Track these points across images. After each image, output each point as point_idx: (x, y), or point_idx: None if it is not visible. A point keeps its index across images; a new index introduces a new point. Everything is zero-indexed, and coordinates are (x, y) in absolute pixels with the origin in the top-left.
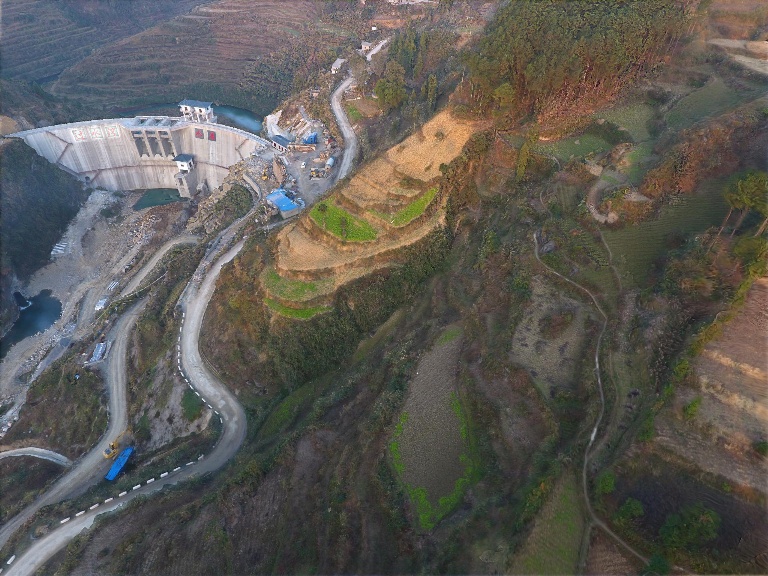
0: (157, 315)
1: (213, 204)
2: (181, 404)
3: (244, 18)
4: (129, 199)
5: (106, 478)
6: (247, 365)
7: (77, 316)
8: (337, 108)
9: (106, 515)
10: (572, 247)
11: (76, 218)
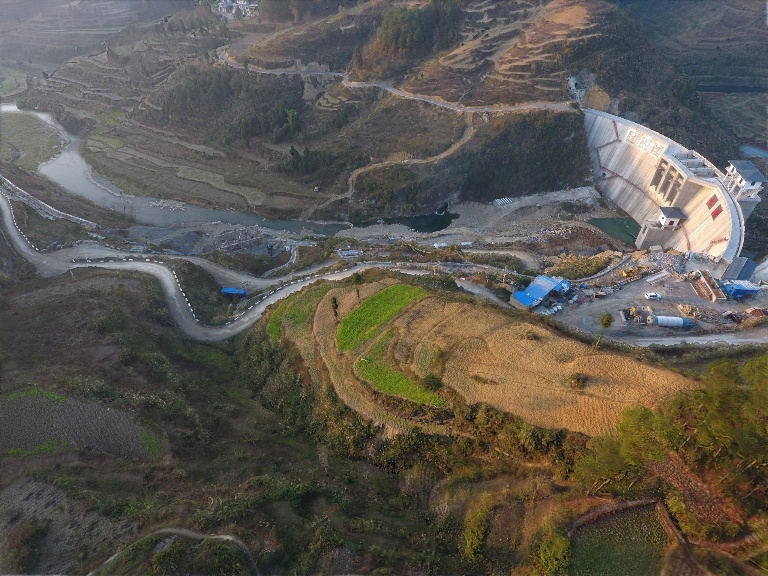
0: None
1: None
2: None
3: None
4: (604, 212)
5: (223, 288)
6: None
7: None
8: None
9: (148, 280)
10: None
11: (548, 193)
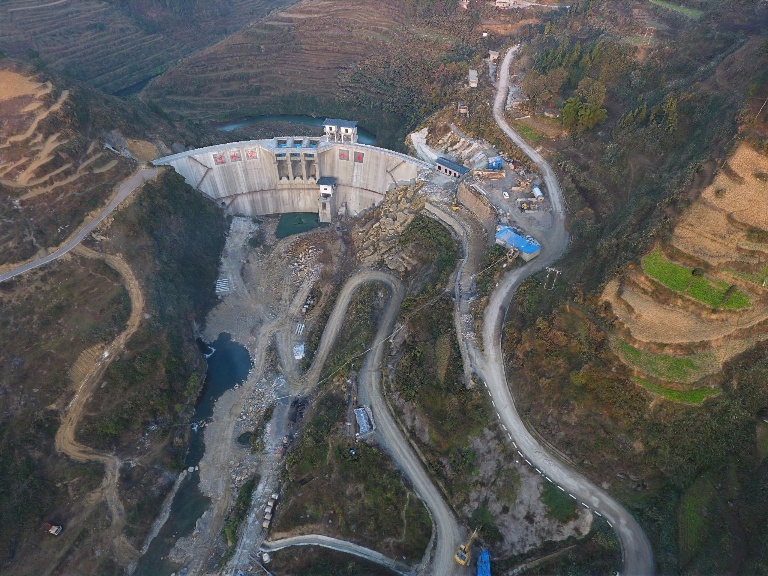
0: (435, 380)
1: (389, 235)
2: (542, 500)
3: (326, 23)
4: (267, 225)
5: None
6: (620, 455)
7: (277, 366)
8: (505, 127)
9: None
10: None
11: (226, 249)
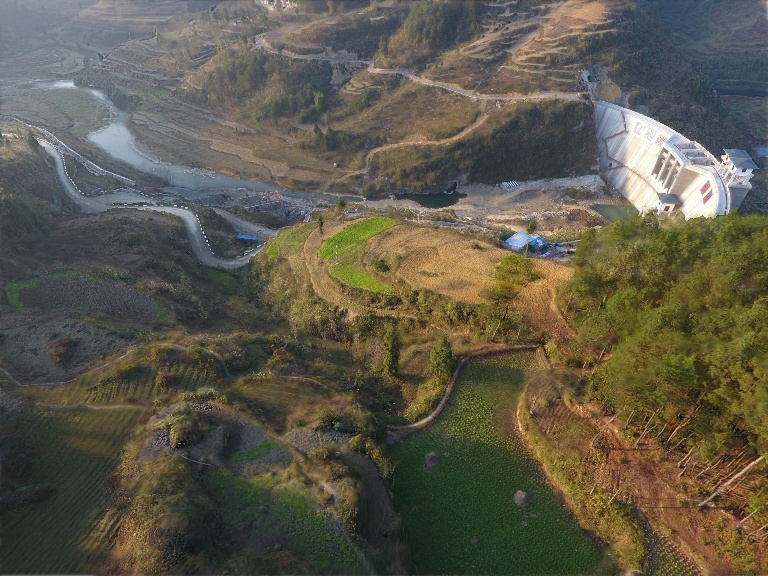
0: None
1: None
2: None
3: None
4: (607, 199)
5: (239, 234)
6: None
7: None
8: None
9: (173, 216)
10: (134, 363)
11: (554, 179)
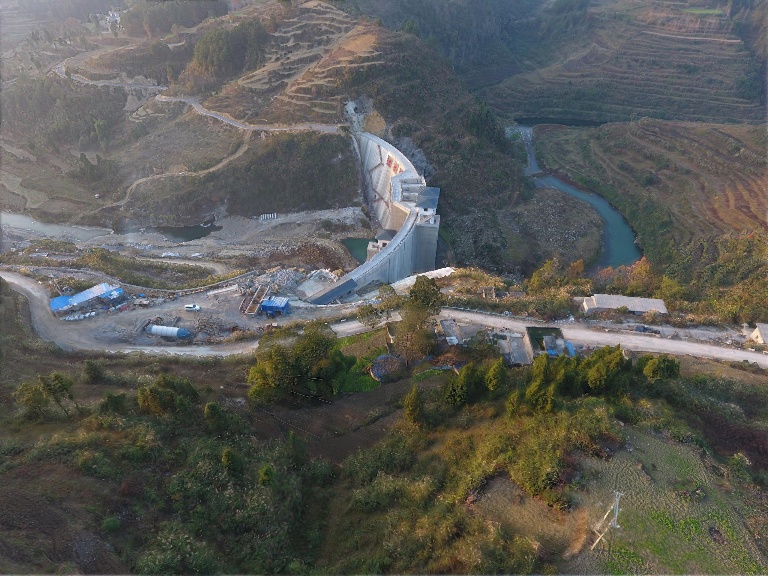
0: (1, 262)
1: None
2: None
3: None
4: (362, 232)
5: None
6: None
7: None
8: None
9: None
10: None
11: (316, 211)
